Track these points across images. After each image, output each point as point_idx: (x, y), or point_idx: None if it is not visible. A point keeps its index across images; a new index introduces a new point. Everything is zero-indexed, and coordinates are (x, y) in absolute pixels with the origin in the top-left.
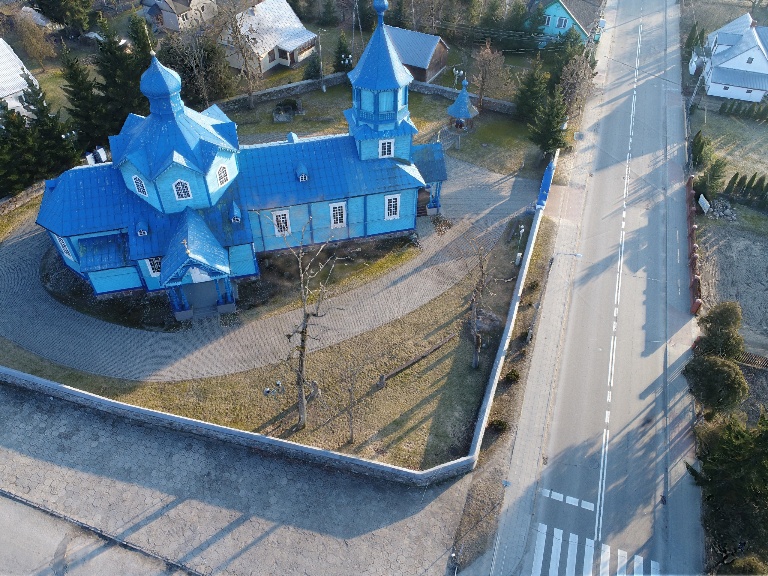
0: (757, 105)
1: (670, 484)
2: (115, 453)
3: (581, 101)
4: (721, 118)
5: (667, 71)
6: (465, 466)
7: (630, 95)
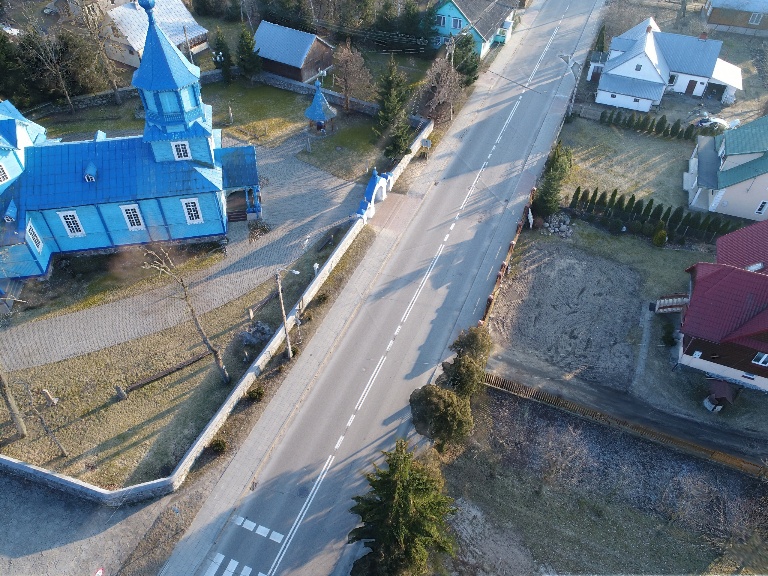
0: (637, 115)
1: None
2: None
3: None
4: (600, 128)
5: (564, 76)
6: (162, 488)
7: (514, 101)
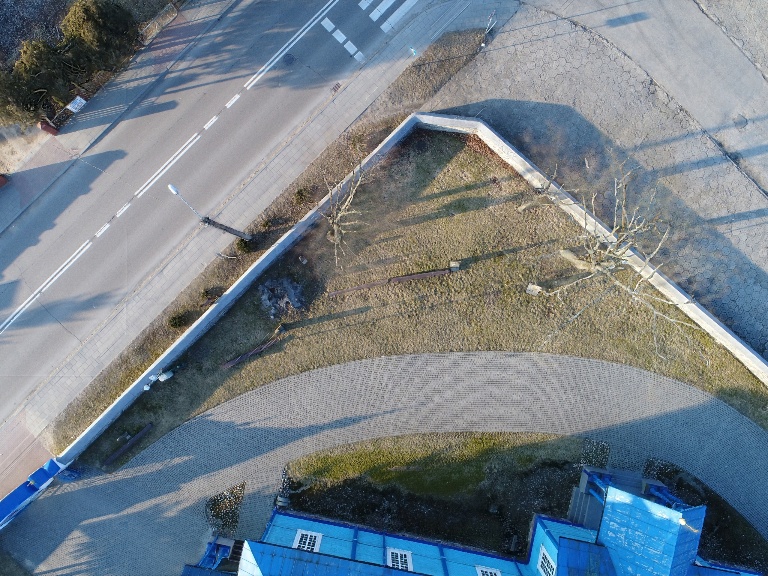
0: None
1: (230, 3)
2: (767, 309)
3: None
4: None
5: None
6: None
7: None
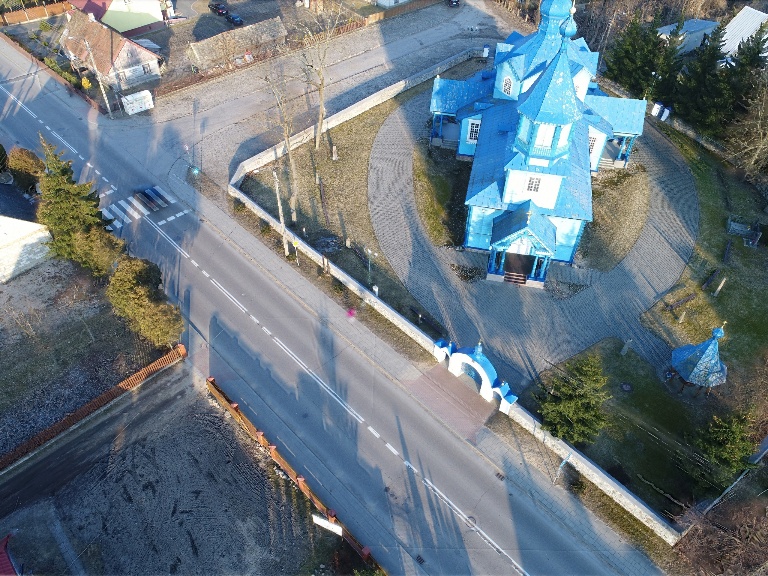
0: None
1: None
2: (353, 97)
3: None
4: None
5: None
6: None
7: None
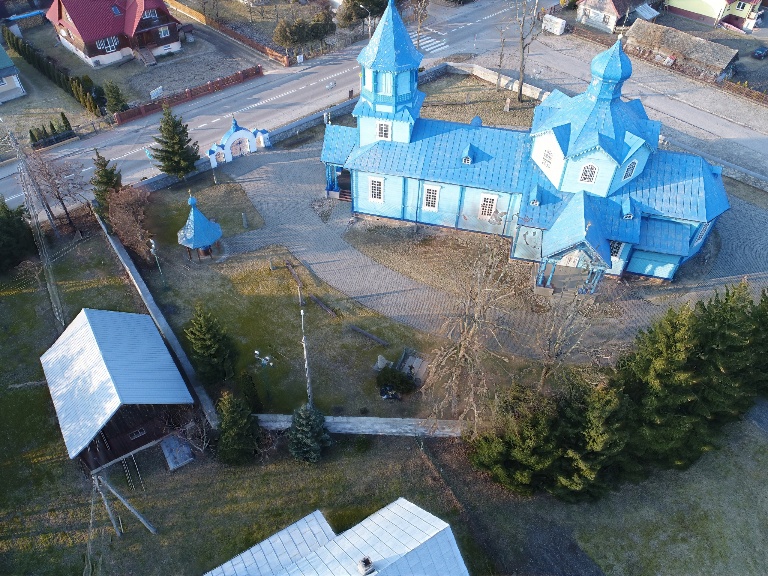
0: None
1: None
2: None
3: (48, 205)
4: None
5: None
6: None
7: None
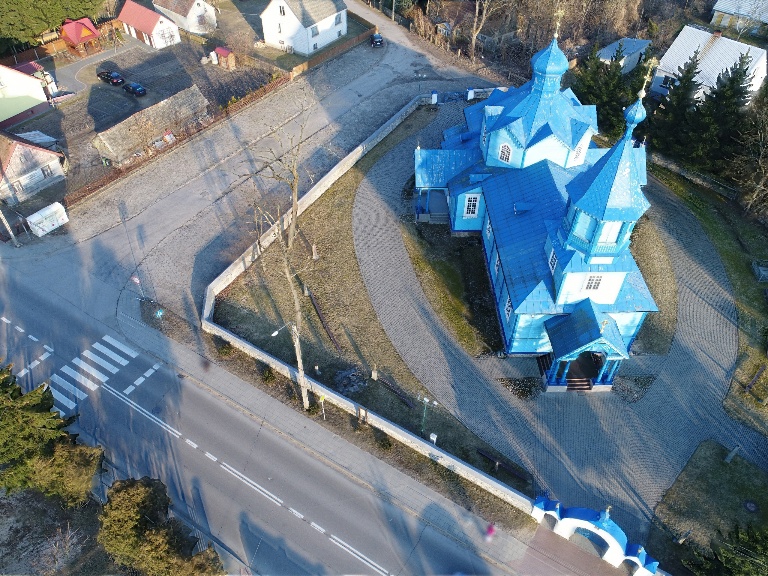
0: None
1: (103, 461)
2: None
3: None
4: None
5: None
6: None
7: None
